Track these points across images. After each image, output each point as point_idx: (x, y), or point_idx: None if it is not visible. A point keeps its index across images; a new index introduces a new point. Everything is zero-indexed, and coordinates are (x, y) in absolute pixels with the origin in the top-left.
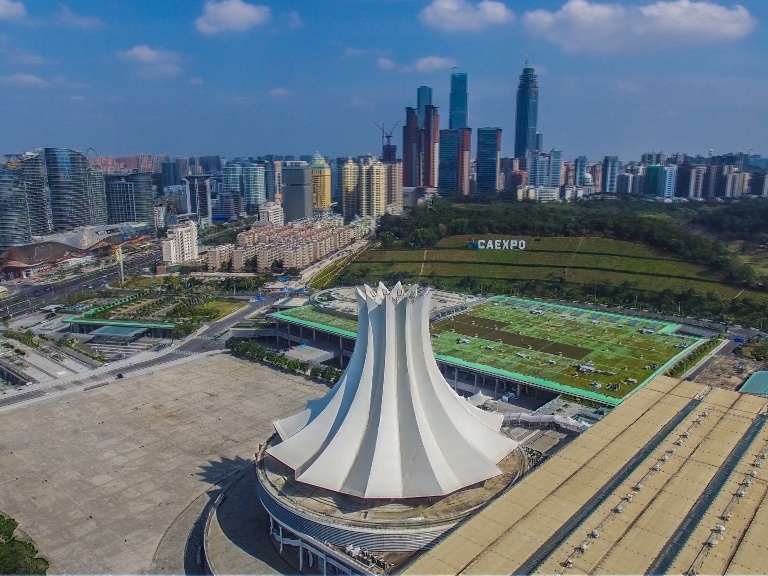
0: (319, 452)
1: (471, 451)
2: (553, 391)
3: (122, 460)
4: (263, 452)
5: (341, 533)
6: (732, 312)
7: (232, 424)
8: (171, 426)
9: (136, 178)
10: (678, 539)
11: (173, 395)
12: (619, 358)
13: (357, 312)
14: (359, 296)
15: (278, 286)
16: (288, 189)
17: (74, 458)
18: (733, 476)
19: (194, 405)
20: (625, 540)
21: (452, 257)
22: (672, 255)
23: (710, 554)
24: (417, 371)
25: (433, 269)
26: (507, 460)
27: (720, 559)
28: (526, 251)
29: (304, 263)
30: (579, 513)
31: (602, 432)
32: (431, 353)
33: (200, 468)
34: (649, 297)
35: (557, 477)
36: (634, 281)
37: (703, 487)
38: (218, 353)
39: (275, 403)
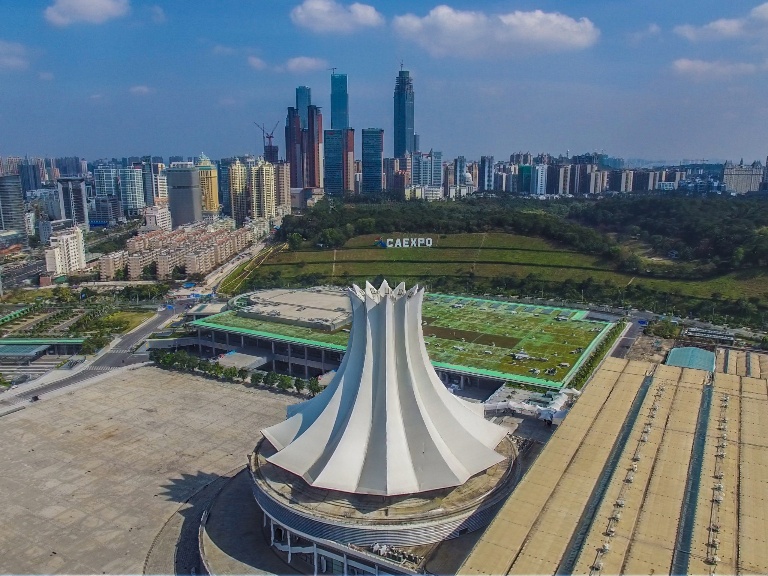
0: (326, 455)
1: (474, 440)
2: (498, 380)
3: (70, 488)
4: (255, 462)
5: (366, 533)
6: (628, 297)
7: (182, 439)
8: (114, 447)
9: (2, 182)
10: (689, 500)
11: (105, 414)
12: (547, 345)
13: (284, 315)
14: (355, 296)
15: (183, 293)
16: (175, 191)
17: (12, 492)
18: (708, 440)
19: (133, 423)
20: (647, 506)
21: (362, 256)
22: (568, 247)
23: (721, 509)
24: (415, 367)
25: (345, 269)
26: (497, 446)
27: (730, 513)
28: (433, 248)
29: (207, 268)
30: (598, 487)
31: (583, 412)
32: (424, 348)
33: (162, 487)
34: (553, 287)
35: (563, 456)
36: (538, 273)
37: (689, 452)
38: (141, 366)
39: (222, 413)
